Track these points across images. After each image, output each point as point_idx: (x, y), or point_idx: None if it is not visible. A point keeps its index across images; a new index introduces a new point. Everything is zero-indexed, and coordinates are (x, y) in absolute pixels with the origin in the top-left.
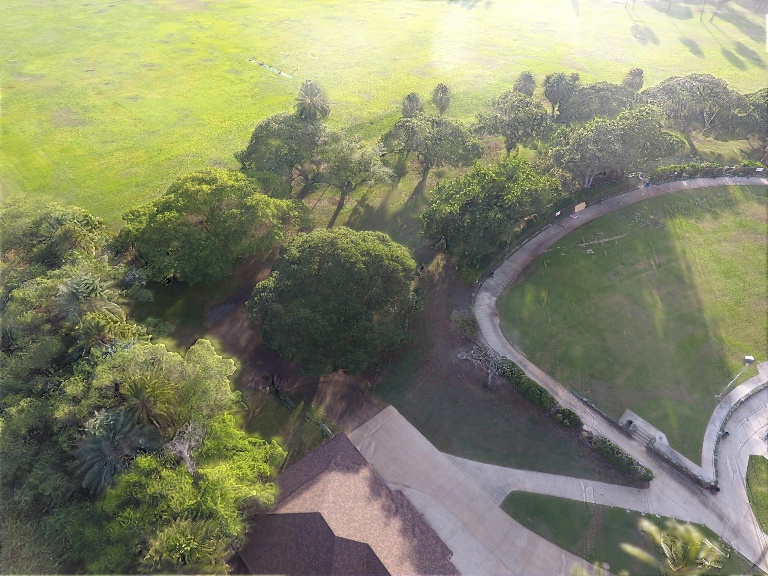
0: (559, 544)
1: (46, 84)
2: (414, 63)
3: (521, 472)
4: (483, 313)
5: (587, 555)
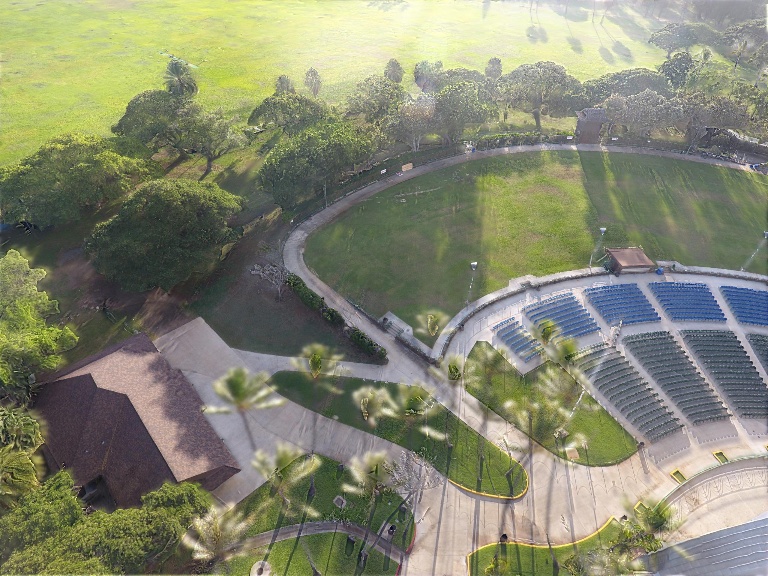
0: (304, 405)
1: None
2: (316, 56)
3: (290, 358)
4: (292, 245)
5: (323, 411)
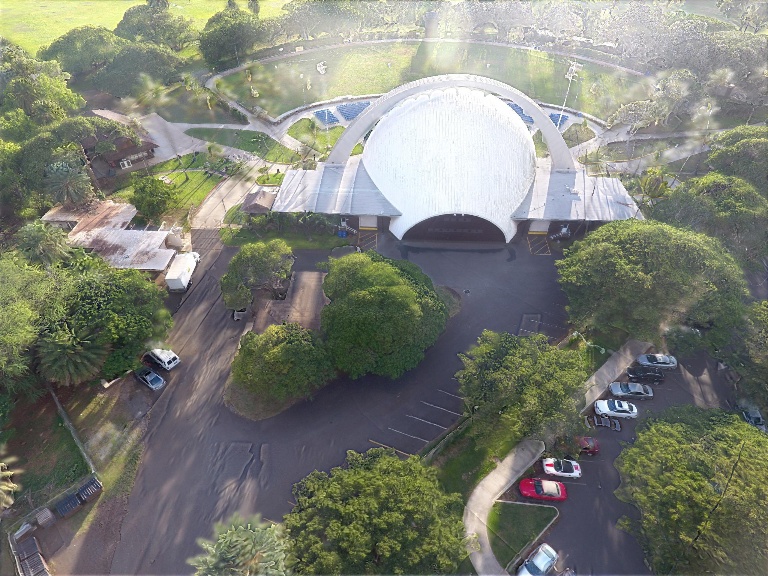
0: (201, 139)
1: (11, 13)
2: None
3: (198, 124)
4: (212, 80)
5: (210, 140)
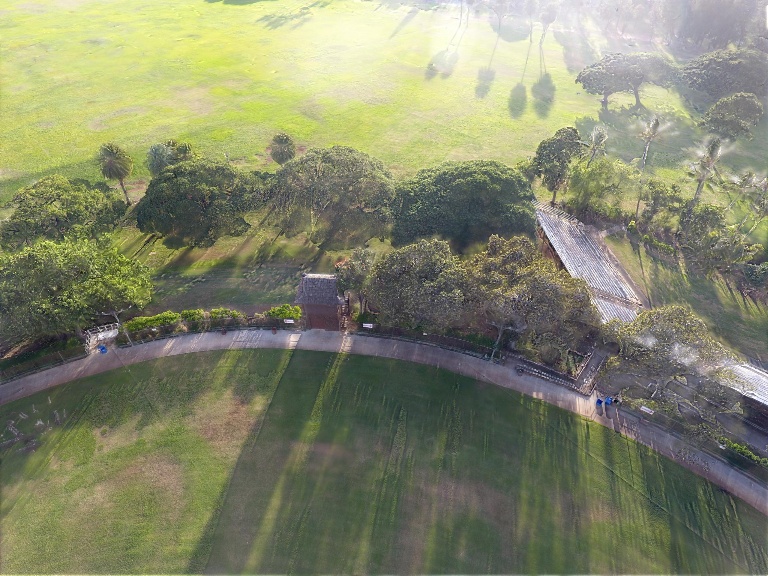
0: None
1: None
2: (108, 108)
3: None
4: None
5: None
